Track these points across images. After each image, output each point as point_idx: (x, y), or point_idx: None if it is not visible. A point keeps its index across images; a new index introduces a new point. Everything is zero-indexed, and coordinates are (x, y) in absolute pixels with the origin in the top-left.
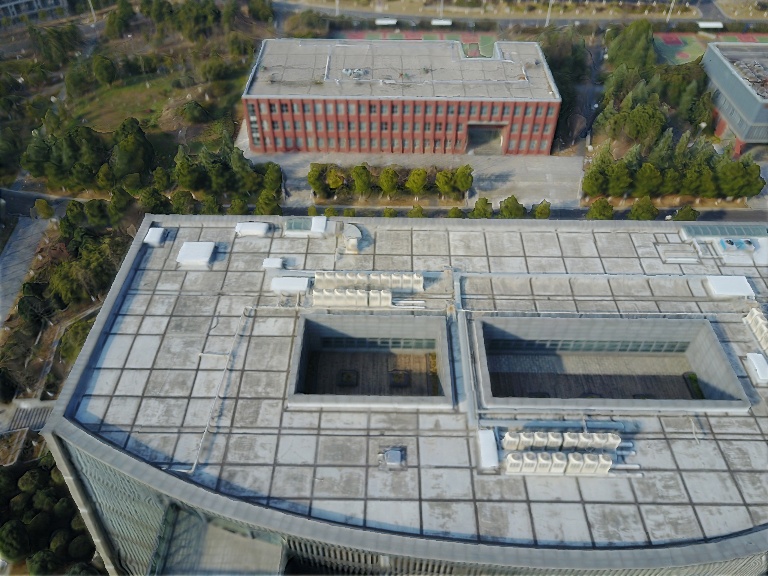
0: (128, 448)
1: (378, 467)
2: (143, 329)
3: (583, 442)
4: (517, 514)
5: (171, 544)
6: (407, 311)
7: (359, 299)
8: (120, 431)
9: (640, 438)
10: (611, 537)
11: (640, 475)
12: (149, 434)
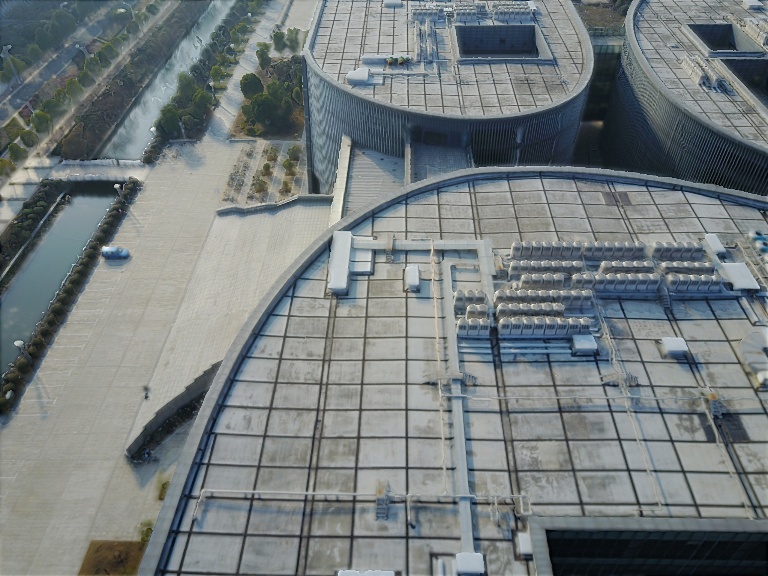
0: (641, 7)
1: (665, 43)
2: (697, 2)
3: (708, 70)
4: (662, 65)
5: (613, 36)
6: (761, 46)
7: (756, 33)
8: (647, 5)
9: (726, 95)
10: (665, 81)
11: (703, 91)
12: (649, 9)
